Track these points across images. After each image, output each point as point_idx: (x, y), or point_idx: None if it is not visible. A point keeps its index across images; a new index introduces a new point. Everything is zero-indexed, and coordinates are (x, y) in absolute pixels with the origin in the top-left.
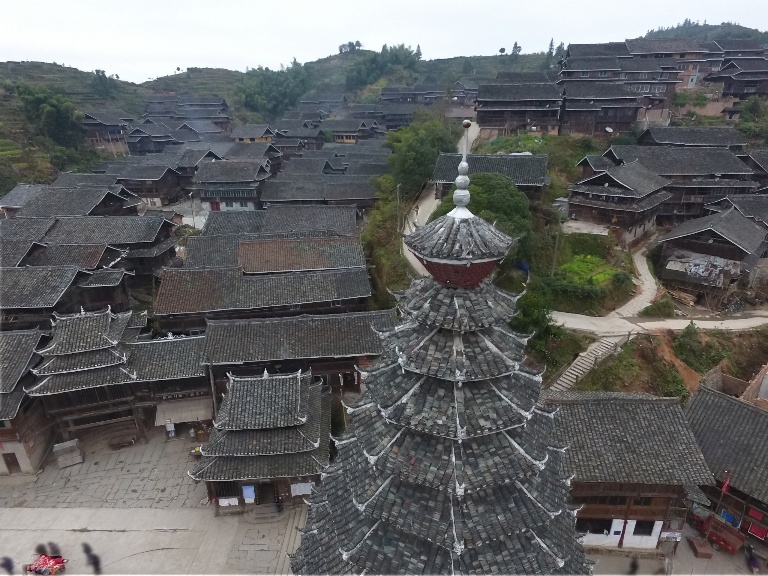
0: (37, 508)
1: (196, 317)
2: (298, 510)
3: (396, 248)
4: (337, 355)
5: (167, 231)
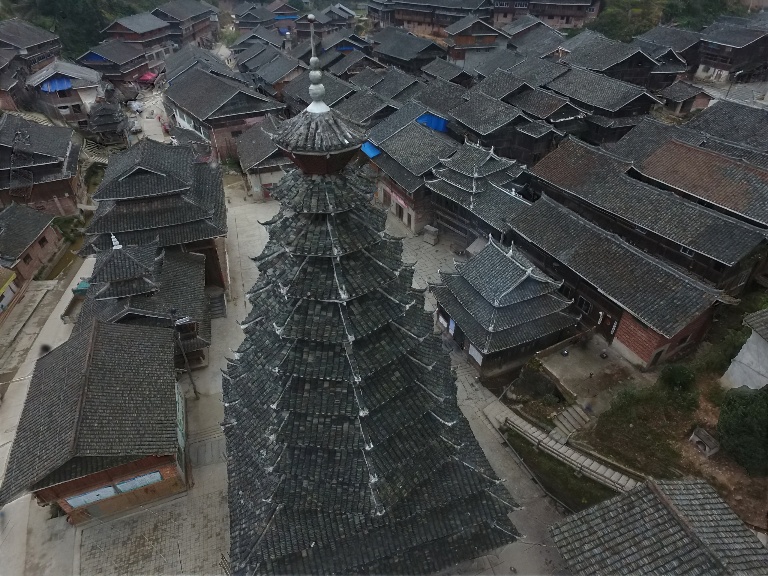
0: None
1: (556, 190)
2: (467, 366)
3: None
4: (601, 289)
5: (647, 107)
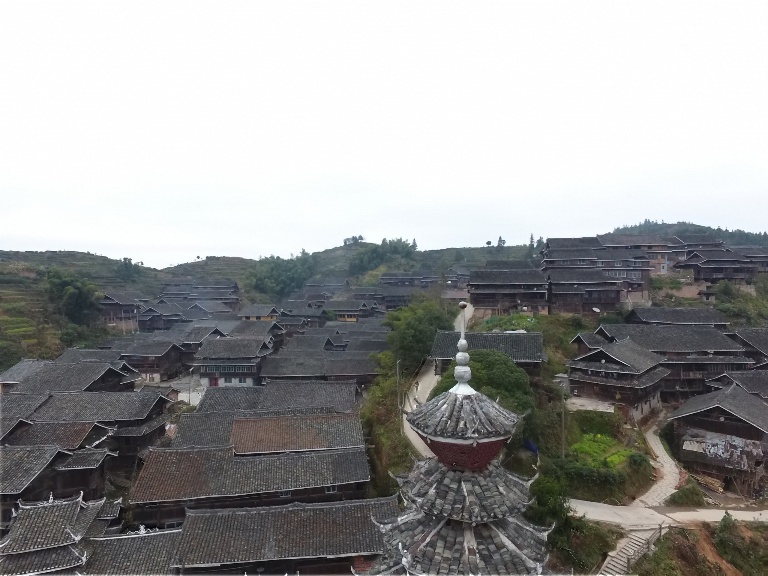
0: None
1: (175, 506)
2: None
3: (396, 426)
4: (330, 555)
5: (161, 408)
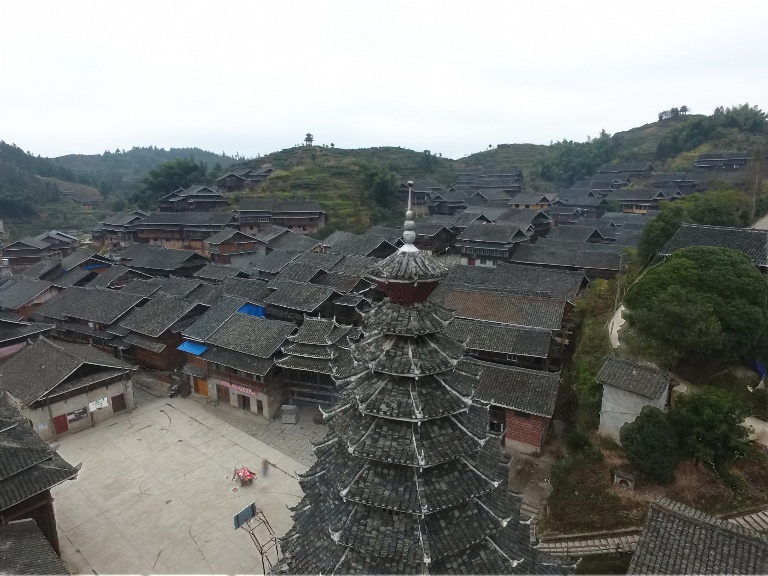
0: (260, 441)
1: None
2: None
3: (604, 319)
4: (484, 400)
5: None
